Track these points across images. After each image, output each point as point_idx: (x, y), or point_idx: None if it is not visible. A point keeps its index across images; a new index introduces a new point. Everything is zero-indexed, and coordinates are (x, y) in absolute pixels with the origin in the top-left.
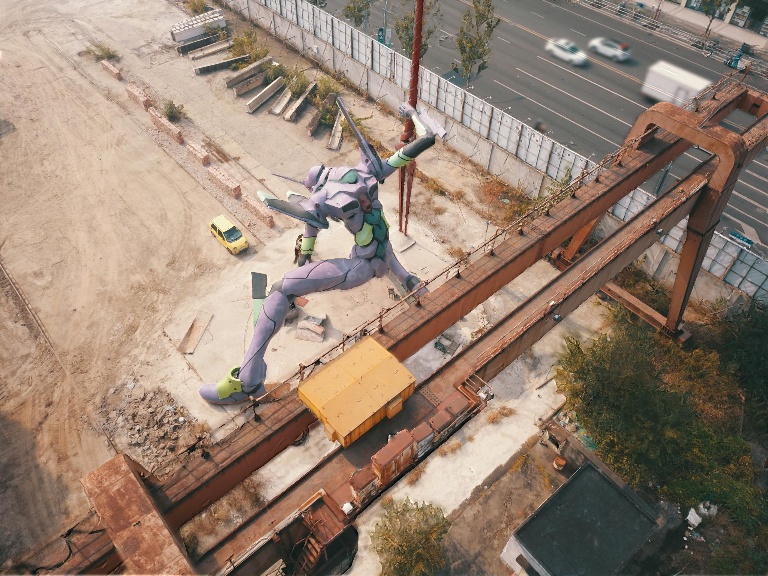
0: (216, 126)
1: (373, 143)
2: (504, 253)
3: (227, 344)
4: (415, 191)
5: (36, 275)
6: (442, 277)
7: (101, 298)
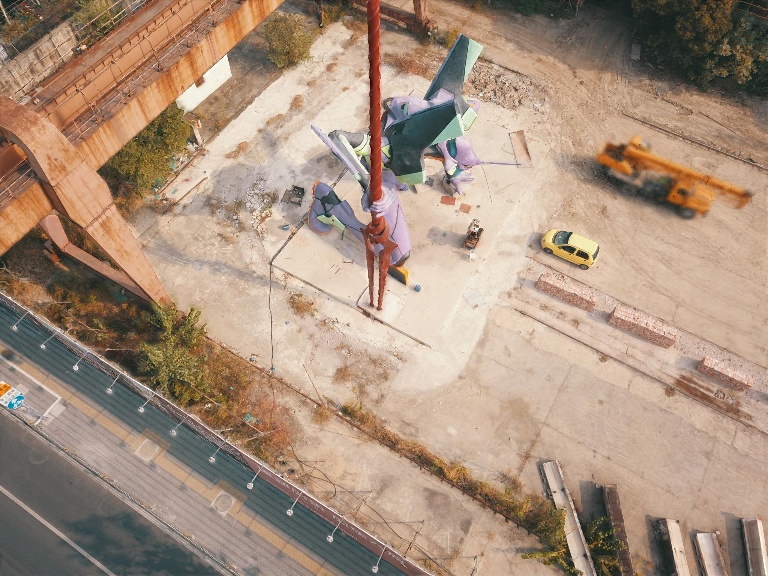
0: (765, 461)
1: (490, 489)
2: (229, 5)
3: (487, 148)
4: (387, 404)
5: (711, 165)
6: (314, 265)
7: (630, 160)
